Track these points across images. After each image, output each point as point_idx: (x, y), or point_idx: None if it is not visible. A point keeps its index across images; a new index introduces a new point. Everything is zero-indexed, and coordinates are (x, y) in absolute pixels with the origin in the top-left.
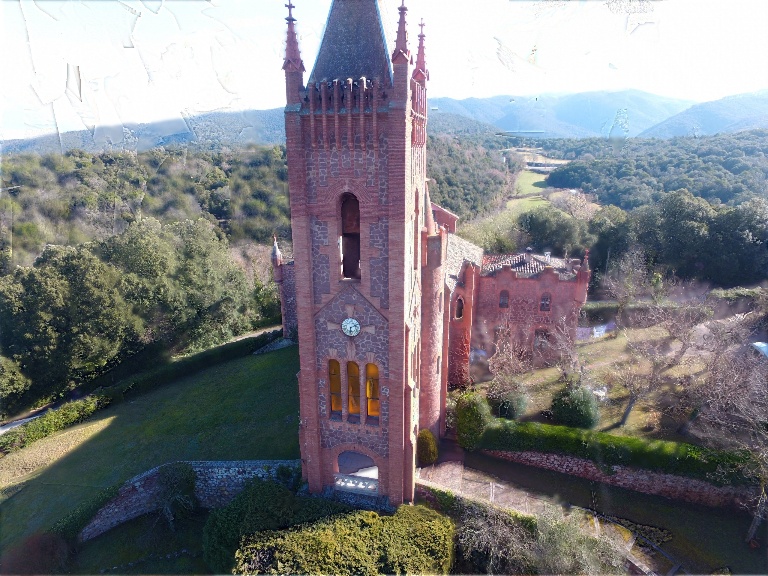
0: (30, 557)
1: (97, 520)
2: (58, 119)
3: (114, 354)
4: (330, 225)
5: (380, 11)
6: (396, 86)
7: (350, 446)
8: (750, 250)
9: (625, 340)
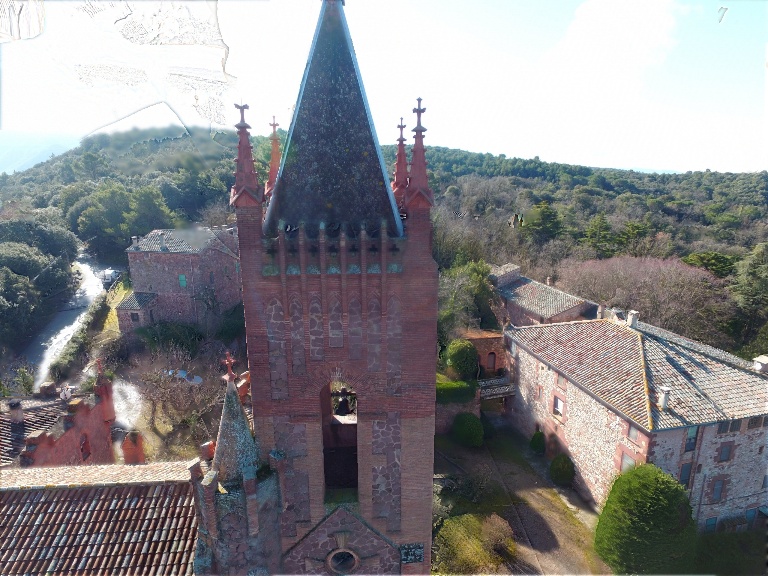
0: None
1: None
2: None
3: None
4: None
5: None
6: None
7: None
8: (13, 315)
9: None
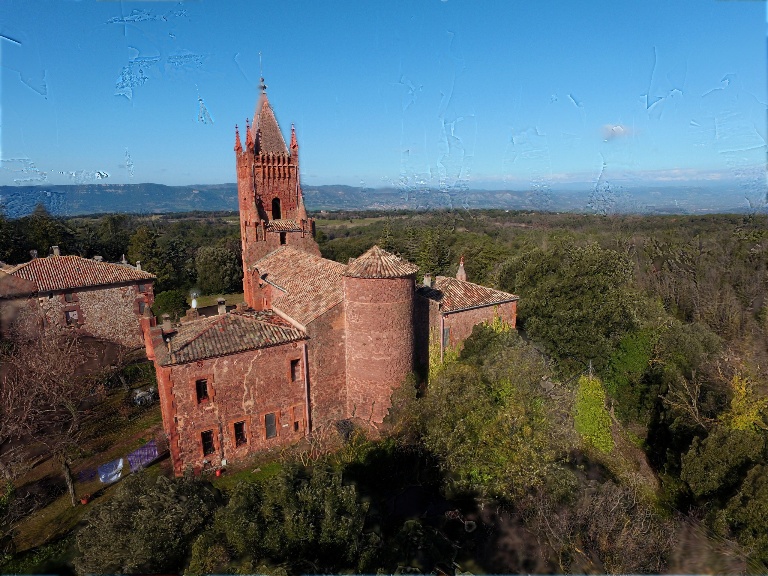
0: None
1: None
2: None
3: None
4: None
5: None
6: None
7: None
8: None
9: (59, 506)
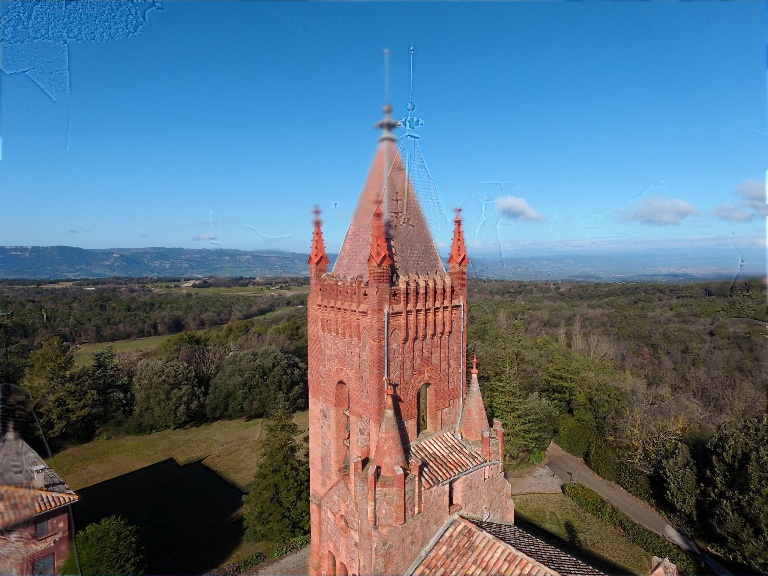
0: None
1: None
2: None
3: (759, 554)
4: None
5: None
6: None
7: None
8: None
9: None
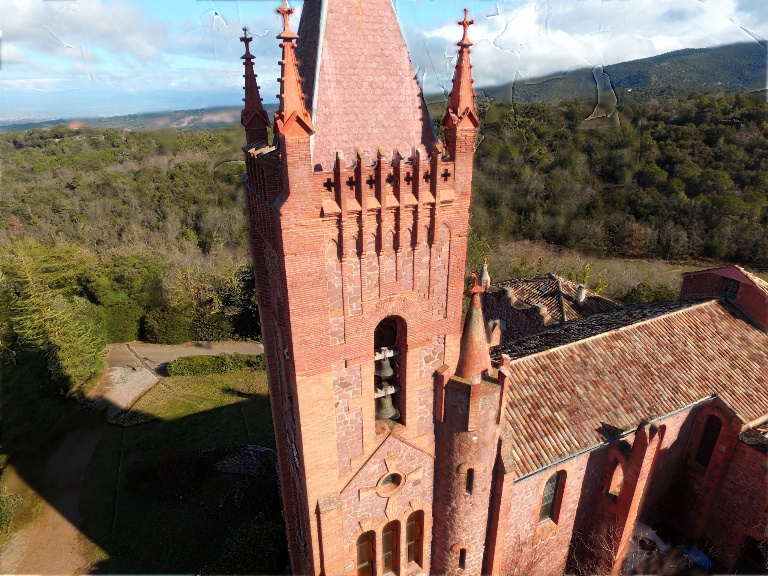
0: (171, 464)
1: (226, 461)
2: (426, 92)
3: None
4: (278, 328)
5: (325, 29)
6: (283, 171)
7: (307, 572)
8: None
9: None
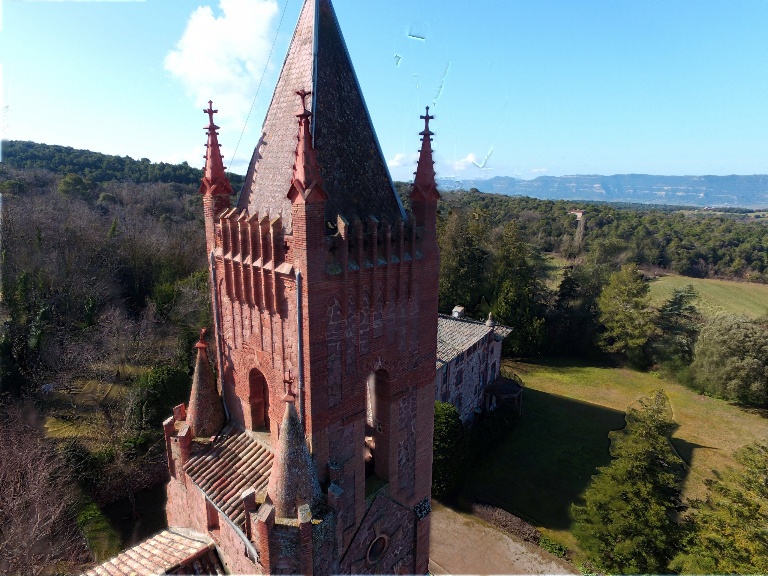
0: None
1: None
2: None
3: None
4: None
5: None
6: None
7: None
8: None
9: None
